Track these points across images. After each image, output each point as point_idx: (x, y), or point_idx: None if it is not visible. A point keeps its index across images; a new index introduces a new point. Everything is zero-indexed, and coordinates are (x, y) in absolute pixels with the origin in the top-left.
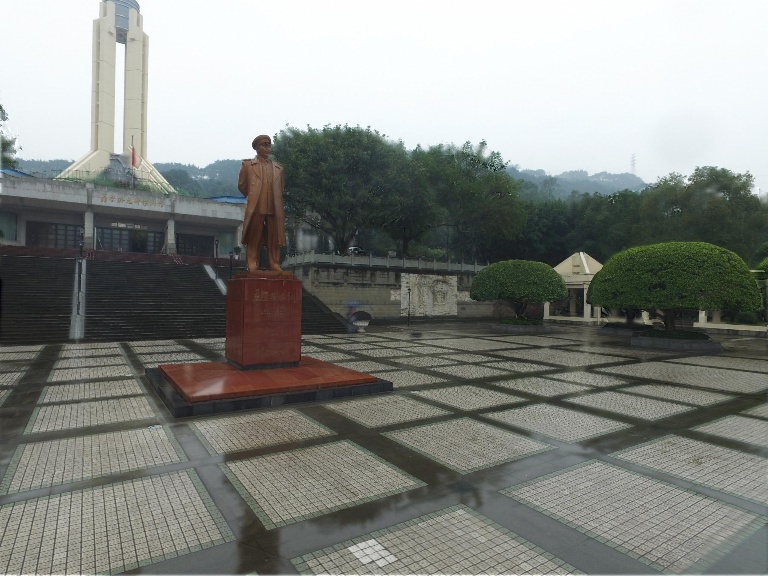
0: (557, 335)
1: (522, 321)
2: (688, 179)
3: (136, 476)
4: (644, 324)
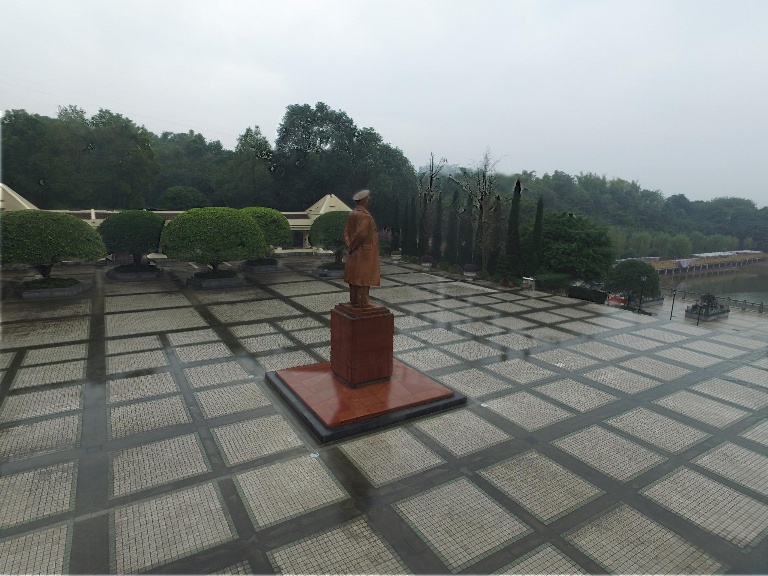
0: (116, 290)
1: (64, 282)
2: (92, 118)
3: None
4: (149, 265)
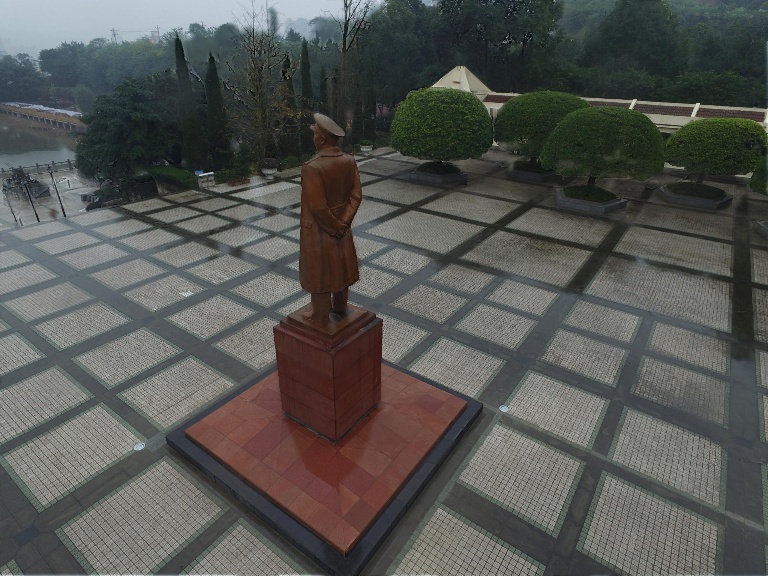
0: None
1: None
2: None
3: (284, 301)
4: None
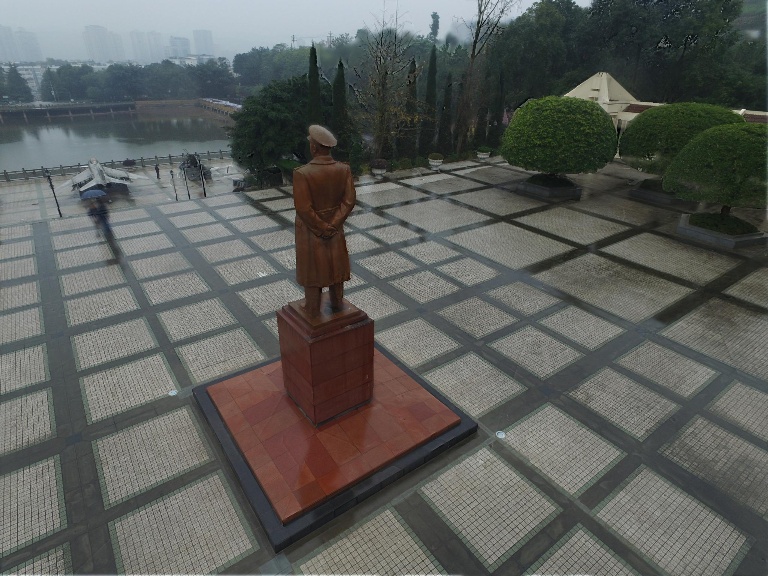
0: None
1: None
2: None
3: None
4: None
